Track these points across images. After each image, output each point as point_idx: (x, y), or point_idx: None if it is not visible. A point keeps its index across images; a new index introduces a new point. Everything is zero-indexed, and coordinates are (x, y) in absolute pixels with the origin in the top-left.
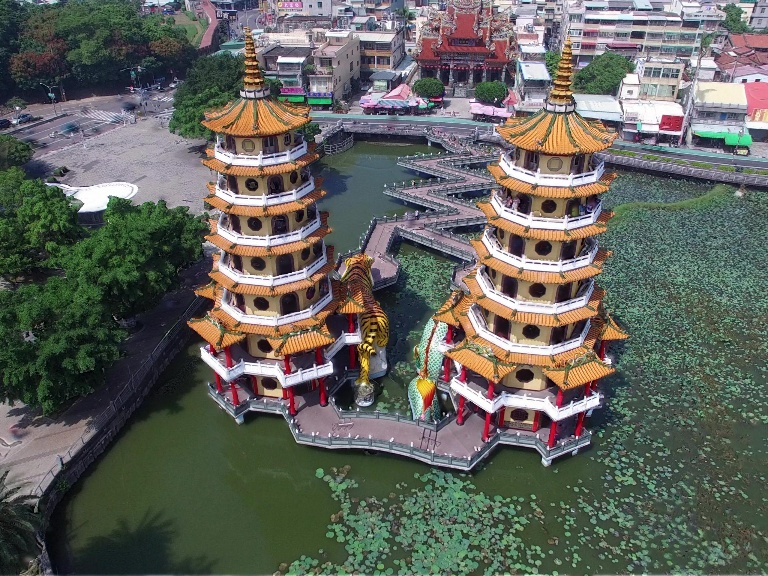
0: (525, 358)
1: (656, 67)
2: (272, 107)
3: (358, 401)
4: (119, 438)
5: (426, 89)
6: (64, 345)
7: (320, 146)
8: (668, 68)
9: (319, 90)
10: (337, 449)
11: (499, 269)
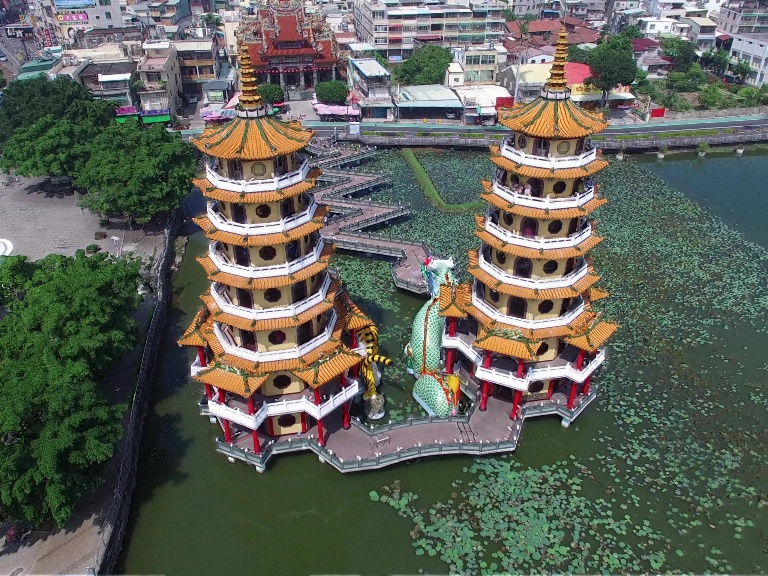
0: (547, 332)
1: (475, 55)
2: (274, 125)
3: (372, 415)
4: (132, 528)
5: (267, 95)
6: (71, 437)
7: None
8: (485, 55)
9: (152, 107)
10: (385, 467)
11: (519, 254)
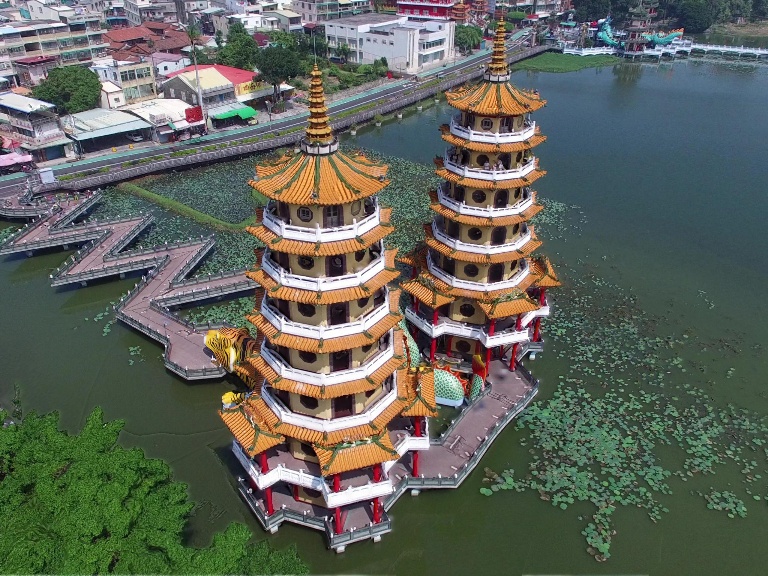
0: (524, 284)
1: (129, 70)
2: None
3: None
4: None
5: None
6: None
7: None
8: (139, 68)
9: None
10: None
11: (506, 223)
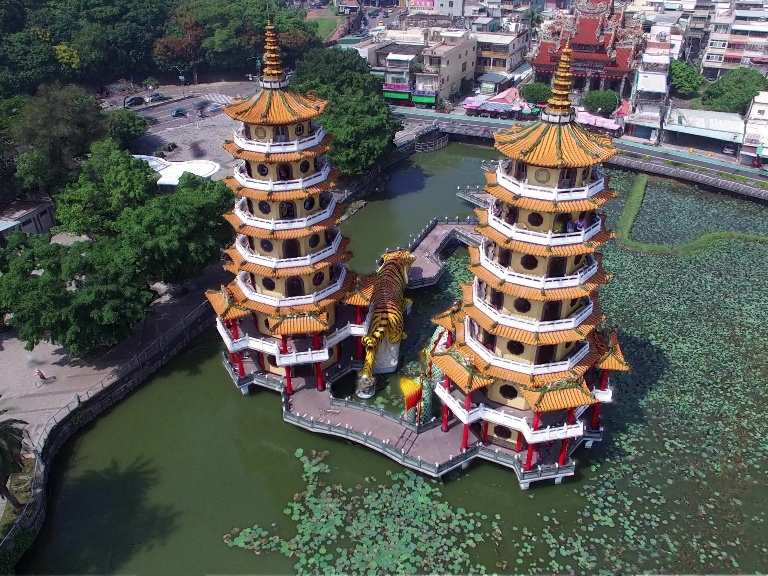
0: (504, 373)
1: None
2: (287, 98)
3: (358, 392)
4: (139, 389)
5: (533, 94)
6: (92, 297)
7: (411, 143)
8: None
9: (425, 88)
10: (318, 433)
11: (483, 278)
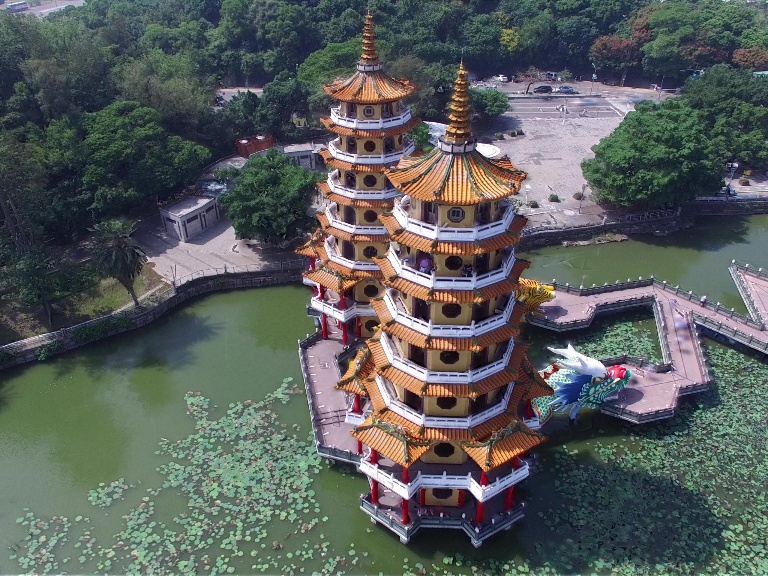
0: (376, 393)
1: None
2: (367, 81)
3: None
4: (274, 286)
5: None
6: (254, 202)
7: (765, 201)
8: None
9: None
10: None
11: None
